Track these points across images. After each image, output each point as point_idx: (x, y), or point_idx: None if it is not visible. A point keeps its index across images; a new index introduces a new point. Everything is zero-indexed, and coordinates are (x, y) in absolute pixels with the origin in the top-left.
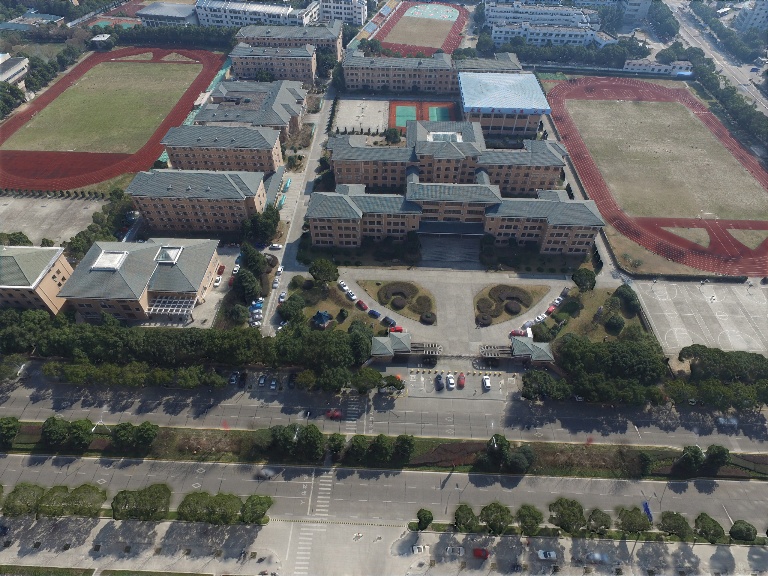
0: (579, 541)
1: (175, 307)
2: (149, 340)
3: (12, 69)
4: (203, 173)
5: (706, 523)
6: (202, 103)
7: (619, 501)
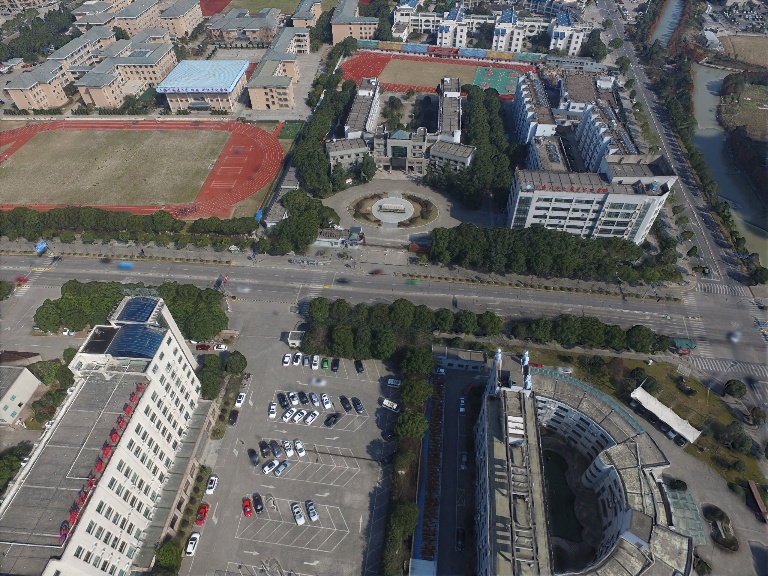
0: None
1: None
2: (54, 20)
3: None
4: (133, 3)
5: None
6: None
7: None
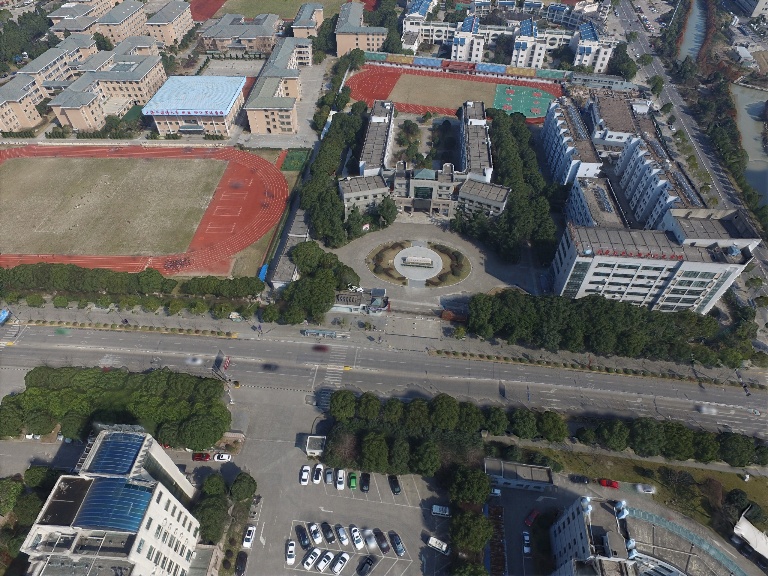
0: None
1: (52, 31)
2: None
3: None
4: (116, 7)
5: None
6: None
7: None
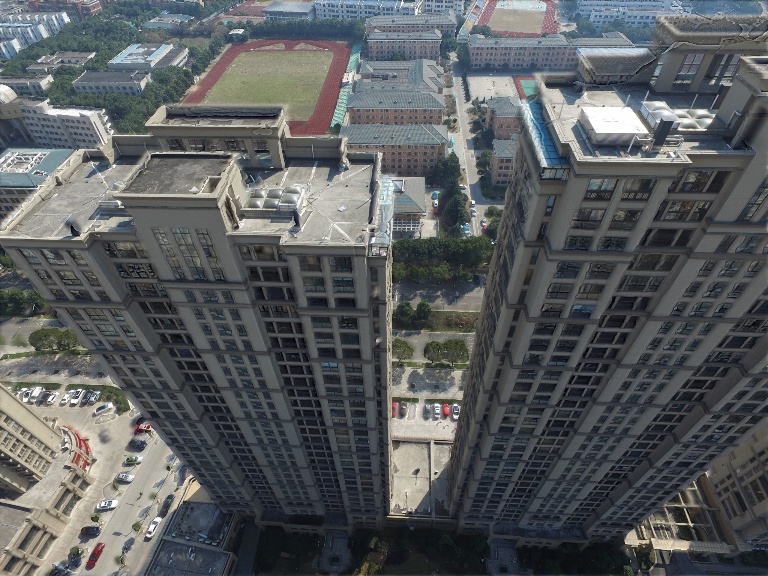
0: None
1: (406, 226)
2: (404, 245)
3: (179, 57)
4: None
5: None
6: (350, 81)
7: None
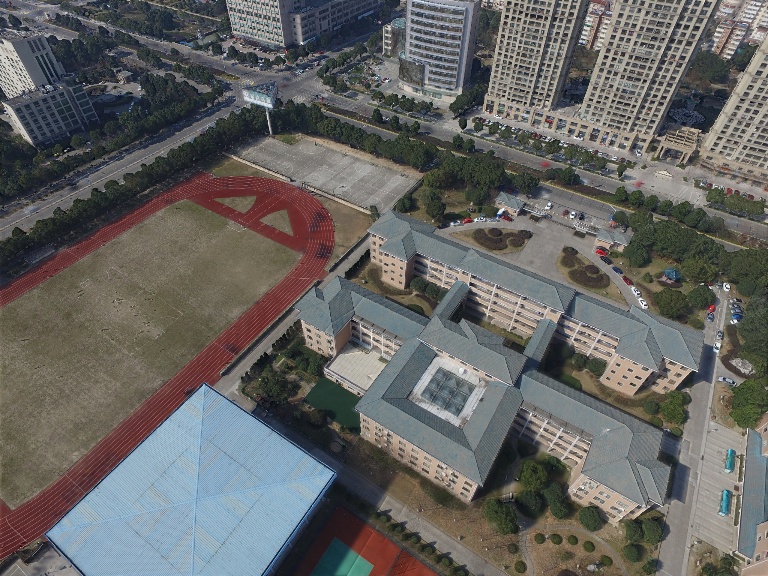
0: (543, 155)
1: None
2: None
3: None
4: None
5: (496, 127)
6: None
7: (513, 156)
